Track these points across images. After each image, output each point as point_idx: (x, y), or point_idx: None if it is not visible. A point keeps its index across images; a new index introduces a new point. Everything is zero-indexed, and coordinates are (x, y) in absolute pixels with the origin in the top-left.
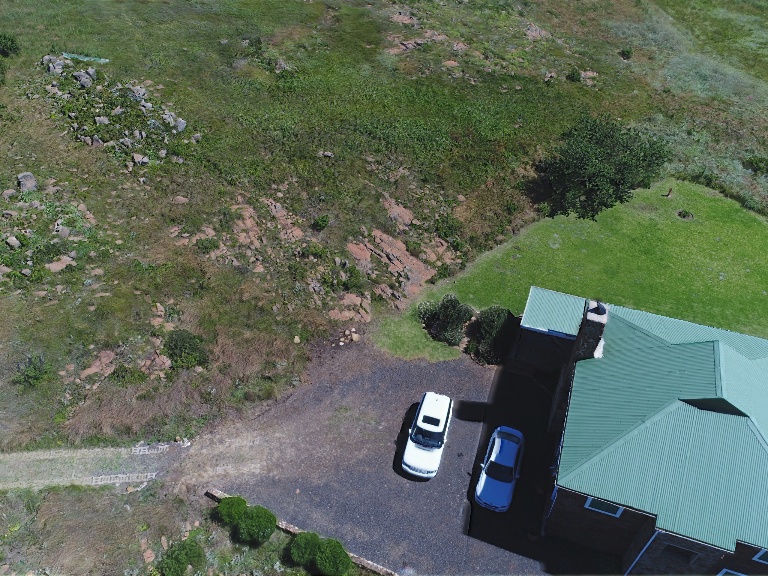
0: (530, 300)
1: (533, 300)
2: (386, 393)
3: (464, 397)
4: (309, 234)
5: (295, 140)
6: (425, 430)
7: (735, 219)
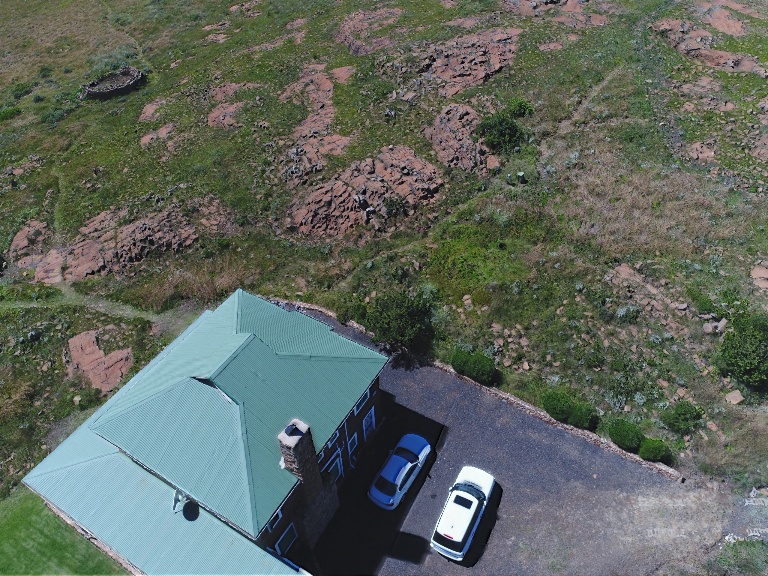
0: None
1: None
2: None
3: (411, 568)
4: None
5: None
6: None
7: None
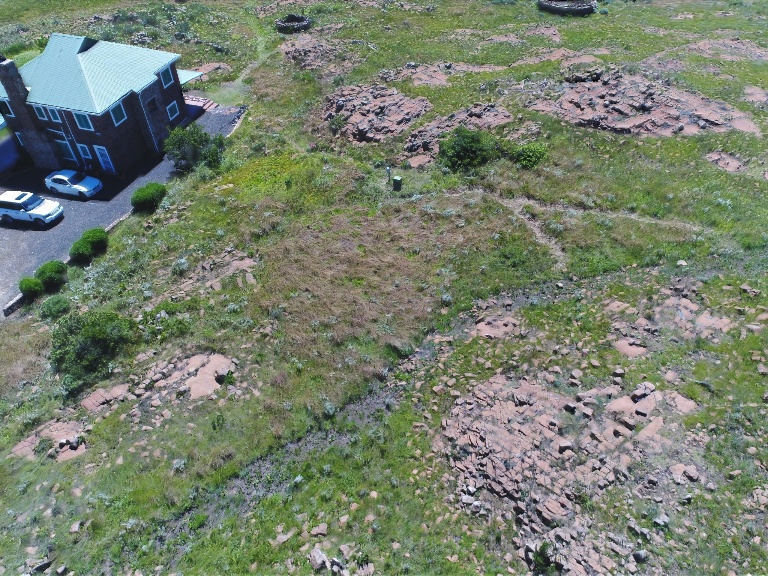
0: None
1: None
2: None
3: None
4: None
5: None
6: (27, 200)
7: None
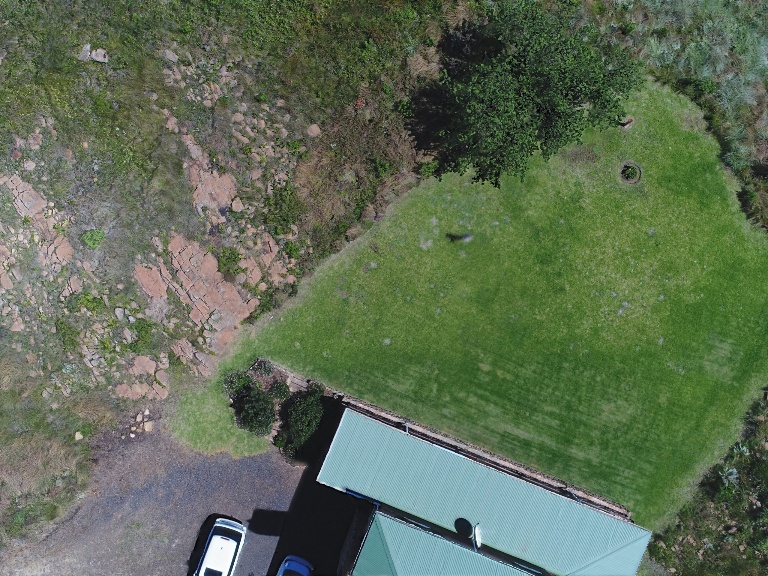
0: (338, 436)
1: (341, 436)
2: (181, 503)
3: (264, 505)
4: (79, 256)
5: (42, 7)
6: None
7: (695, 187)
